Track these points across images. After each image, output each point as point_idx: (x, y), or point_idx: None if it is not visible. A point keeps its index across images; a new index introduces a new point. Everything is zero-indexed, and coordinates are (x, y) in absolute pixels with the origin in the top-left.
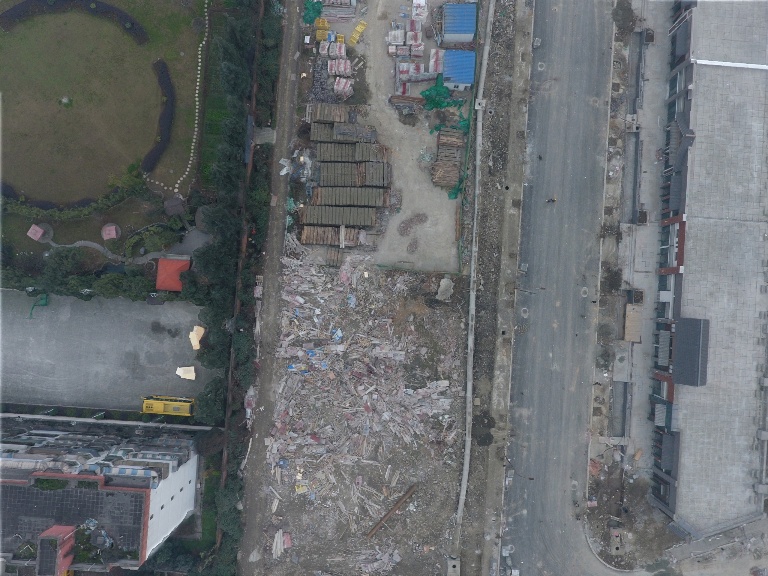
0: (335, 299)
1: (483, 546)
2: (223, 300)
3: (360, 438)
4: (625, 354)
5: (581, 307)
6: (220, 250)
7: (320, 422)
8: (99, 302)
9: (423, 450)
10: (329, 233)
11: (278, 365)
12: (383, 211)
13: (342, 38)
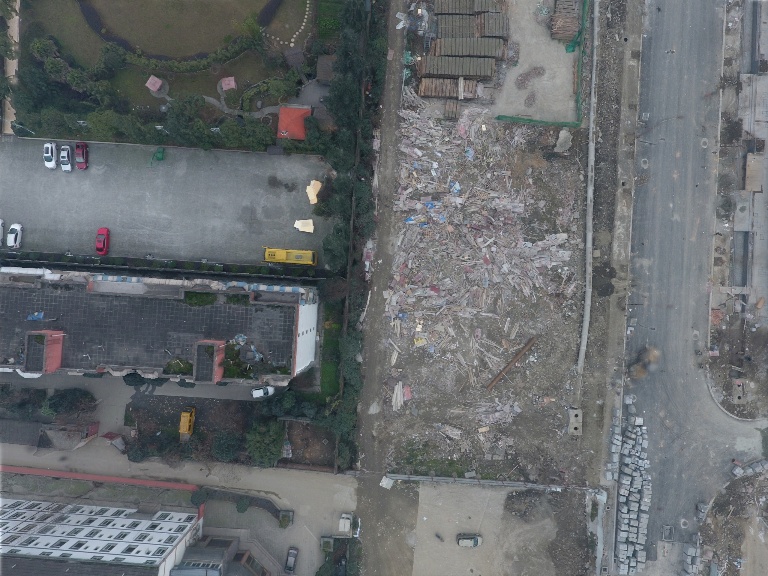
0: (453, 153)
1: (605, 395)
2: (349, 143)
3: (479, 290)
4: (746, 204)
5: (701, 158)
6: (353, 84)
7: (439, 275)
8: (215, 157)
9: (542, 303)
10: (448, 85)
11: (396, 218)
12: (500, 64)
13: None
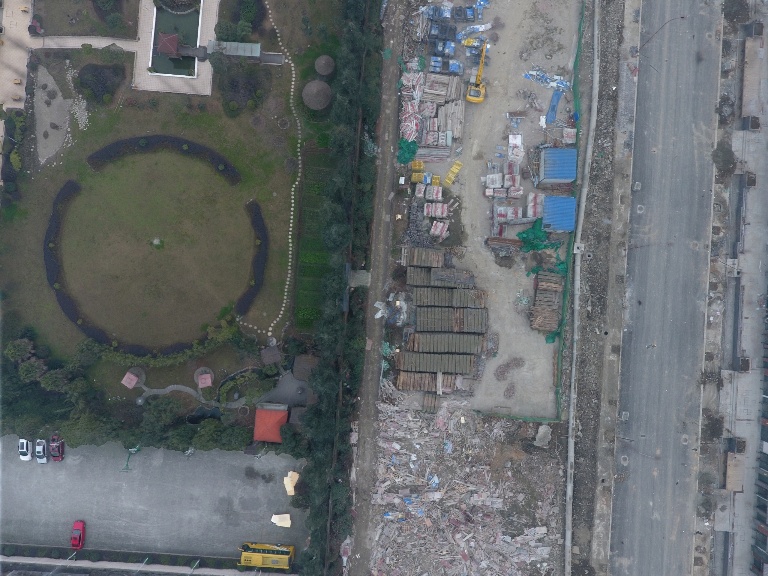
0: (431, 444)
1: None
2: (325, 457)
3: None
4: (727, 503)
5: (682, 455)
6: (327, 415)
7: (417, 570)
8: (192, 447)
9: None
10: (426, 379)
11: (374, 512)
12: (480, 355)
13: (438, 179)
